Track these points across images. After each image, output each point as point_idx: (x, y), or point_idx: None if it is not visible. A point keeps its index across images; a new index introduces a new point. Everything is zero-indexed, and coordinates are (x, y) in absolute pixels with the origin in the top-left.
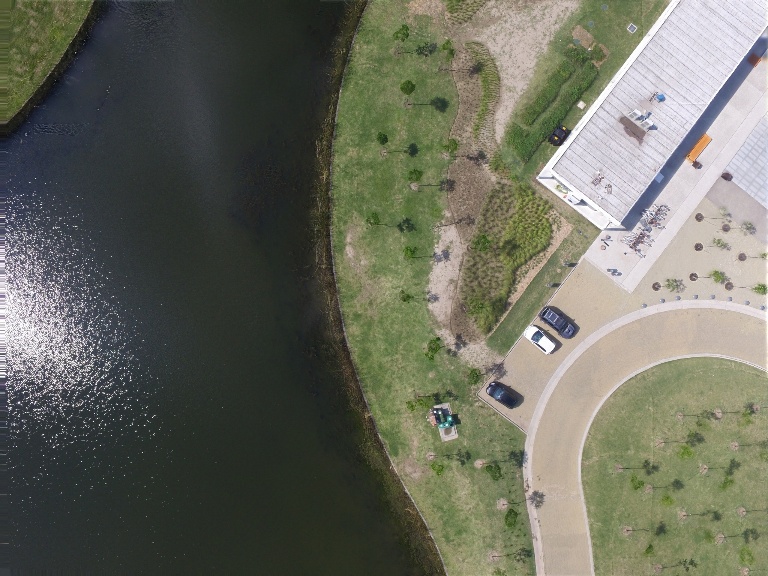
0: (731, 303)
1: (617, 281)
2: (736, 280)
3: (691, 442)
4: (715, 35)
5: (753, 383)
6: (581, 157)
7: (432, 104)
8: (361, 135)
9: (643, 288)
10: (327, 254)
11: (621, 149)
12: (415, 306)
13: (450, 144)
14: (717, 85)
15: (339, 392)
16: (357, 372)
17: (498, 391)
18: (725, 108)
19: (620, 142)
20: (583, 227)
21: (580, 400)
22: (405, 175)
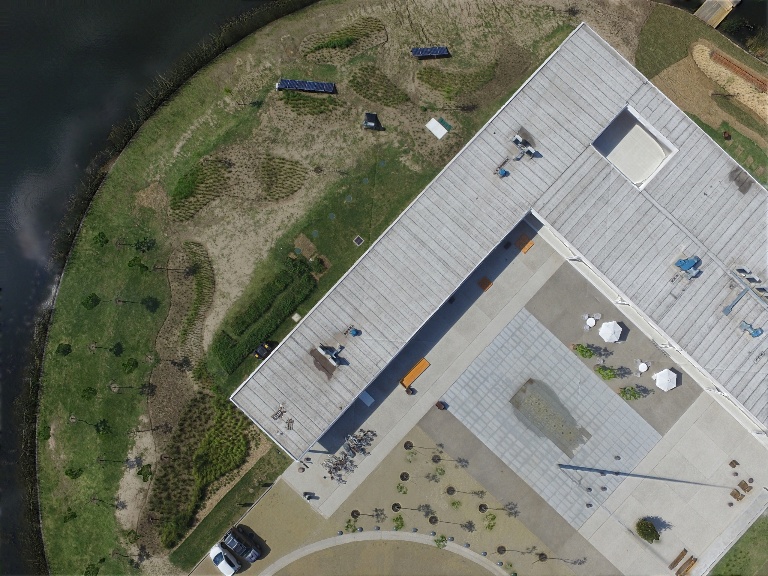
0: (434, 538)
1: (314, 505)
2: (442, 514)
3: None
4: (423, 269)
5: None
6: (264, 388)
7: (143, 303)
8: (74, 325)
9: (341, 514)
10: (32, 441)
11: (308, 383)
12: (104, 510)
13: (128, 364)
14: (418, 323)
15: None
16: (49, 566)
17: None
18: (448, 332)
19: (308, 375)
20: None
21: None
22: (107, 375)
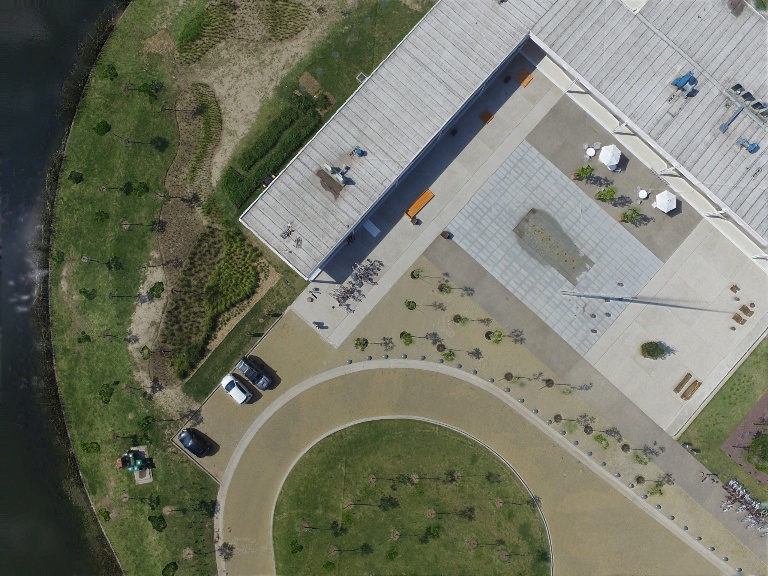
0: (442, 365)
1: (323, 335)
2: (449, 342)
3: (384, 506)
4: (425, 91)
5: (457, 450)
6: (273, 208)
7: (152, 143)
8: (85, 169)
9: (350, 344)
10: (45, 286)
11: (315, 203)
12: (117, 345)
13: (139, 187)
14: (422, 143)
15: (47, 425)
16: (63, 407)
17: (188, 438)
18: (451, 164)
19: (315, 195)
20: (291, 277)
21: (277, 453)
22: (118, 213)
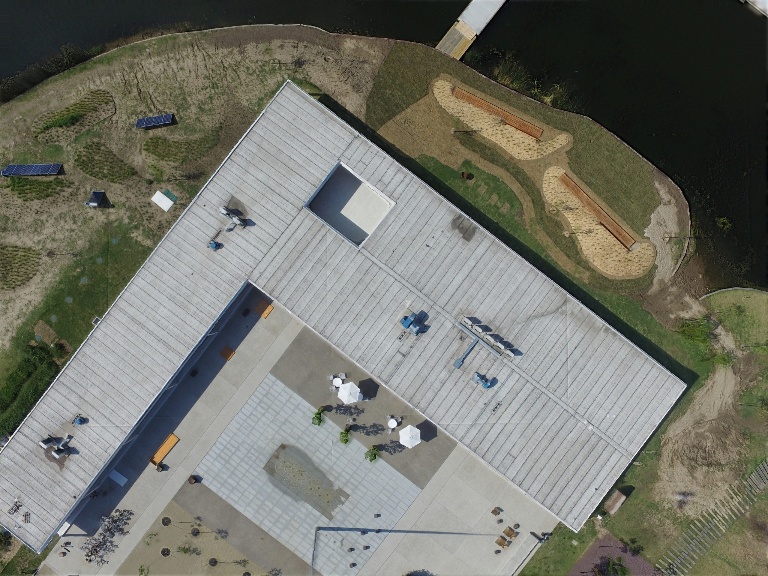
0: None
1: None
2: None
3: None
4: (143, 351)
5: None
6: None
7: None
8: None
9: None
10: None
11: (41, 475)
12: None
13: None
14: (144, 405)
15: None
16: None
17: None
18: (195, 406)
19: (40, 467)
20: None
21: None
22: None
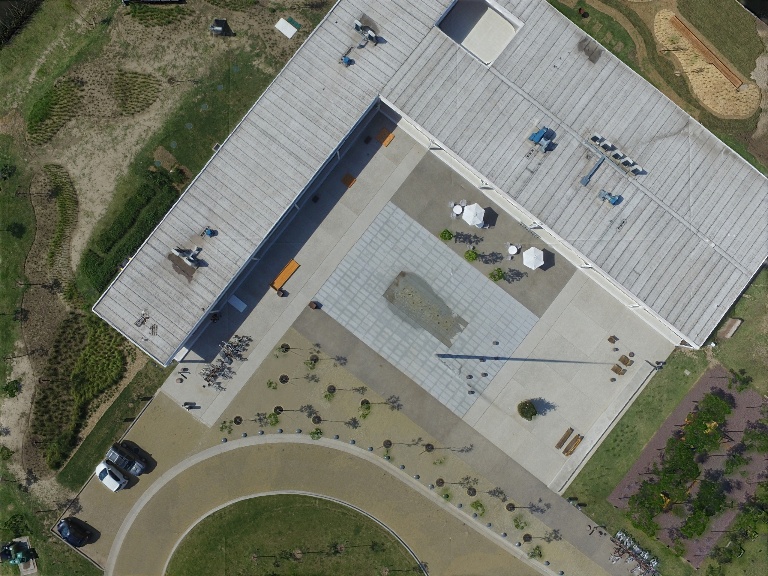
0: None
1: (195, 415)
2: (324, 413)
3: None
4: (274, 164)
5: (339, 521)
6: (125, 296)
7: (9, 230)
8: None
9: None
10: None
11: (168, 287)
12: None
13: None
14: (274, 218)
15: None
16: None
17: (65, 529)
18: (315, 232)
19: (168, 280)
20: None
21: (158, 536)
22: None
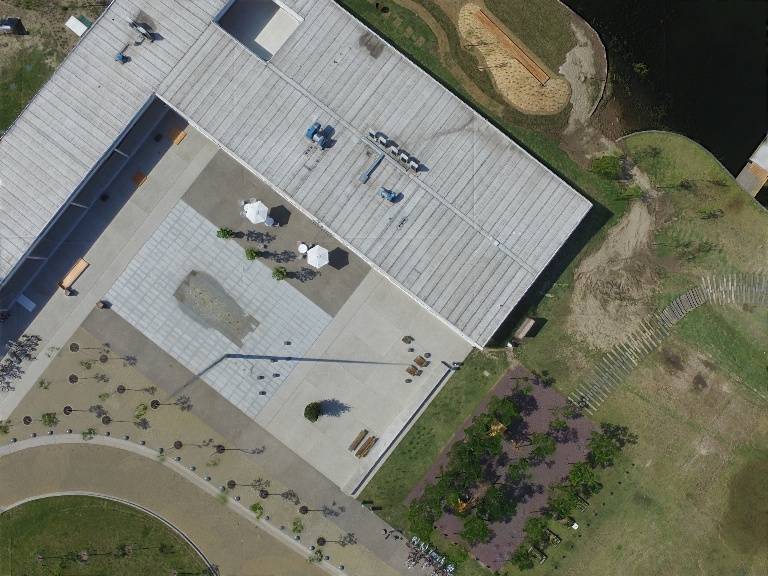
0: (109, 438)
1: None
2: (114, 414)
3: None
4: (49, 163)
5: (127, 523)
6: None
7: None
8: None
9: (13, 422)
10: None
11: None
12: None
13: None
14: (48, 217)
15: None
16: None
17: None
18: (105, 231)
19: None
20: None
21: None
22: None
